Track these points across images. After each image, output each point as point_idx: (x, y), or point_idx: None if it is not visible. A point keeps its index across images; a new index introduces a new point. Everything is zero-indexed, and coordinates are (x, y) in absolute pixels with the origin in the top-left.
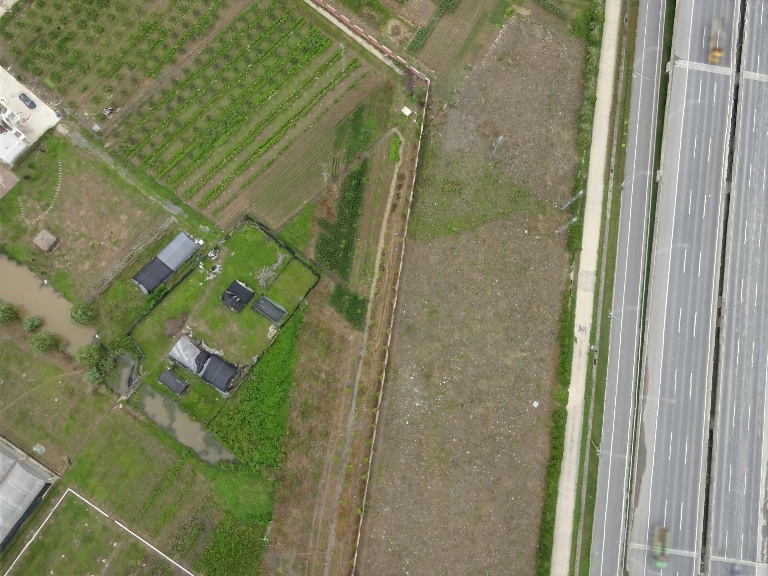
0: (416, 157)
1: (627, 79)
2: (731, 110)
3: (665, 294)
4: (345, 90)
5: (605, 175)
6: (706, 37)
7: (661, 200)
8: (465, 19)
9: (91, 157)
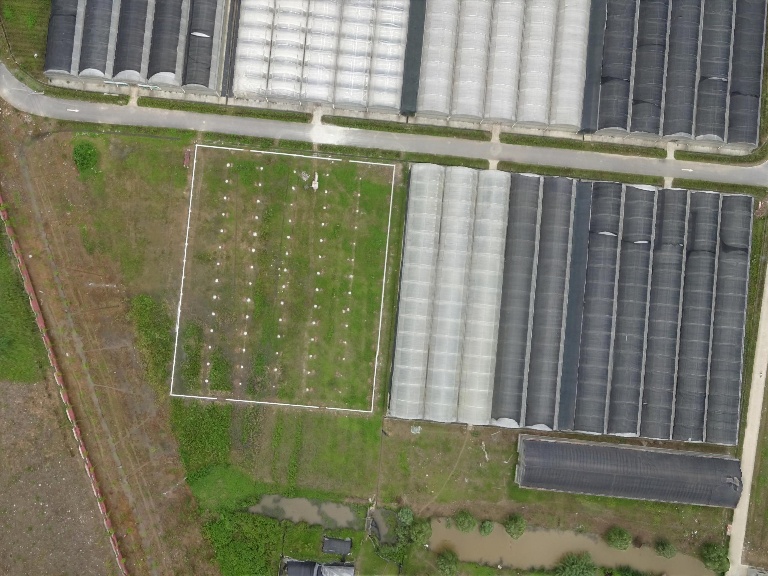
0: None
1: None
2: None
3: None
4: None
5: None
6: None
7: None
8: None
9: None
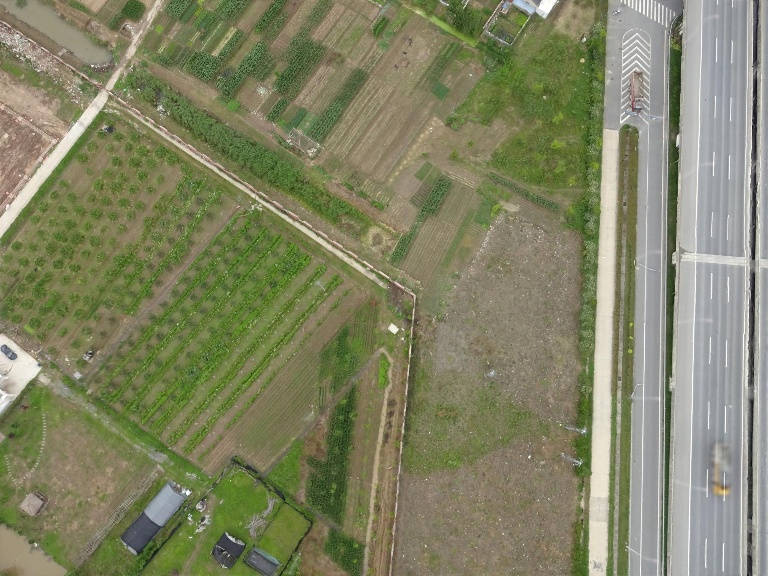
0: (406, 381)
1: (630, 273)
2: (748, 306)
3: (687, 523)
4: (328, 311)
5: (612, 385)
6: (714, 224)
7: (676, 416)
8: (449, 221)
9: (74, 406)
